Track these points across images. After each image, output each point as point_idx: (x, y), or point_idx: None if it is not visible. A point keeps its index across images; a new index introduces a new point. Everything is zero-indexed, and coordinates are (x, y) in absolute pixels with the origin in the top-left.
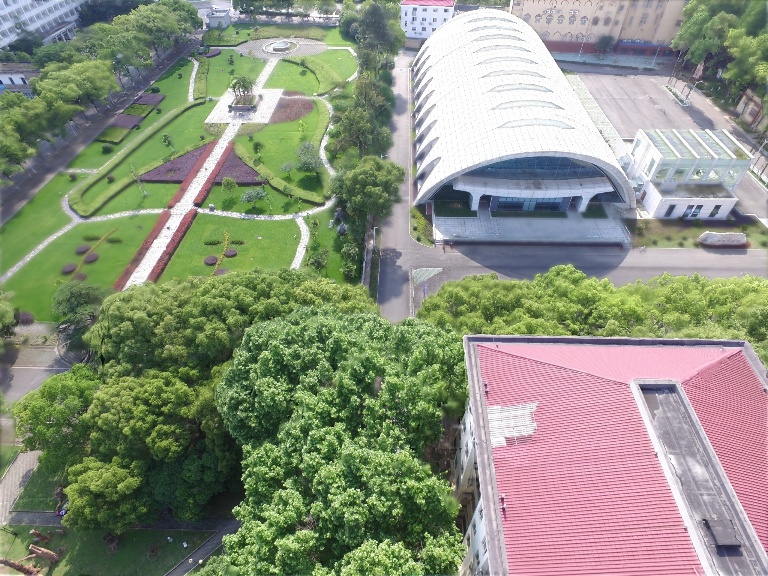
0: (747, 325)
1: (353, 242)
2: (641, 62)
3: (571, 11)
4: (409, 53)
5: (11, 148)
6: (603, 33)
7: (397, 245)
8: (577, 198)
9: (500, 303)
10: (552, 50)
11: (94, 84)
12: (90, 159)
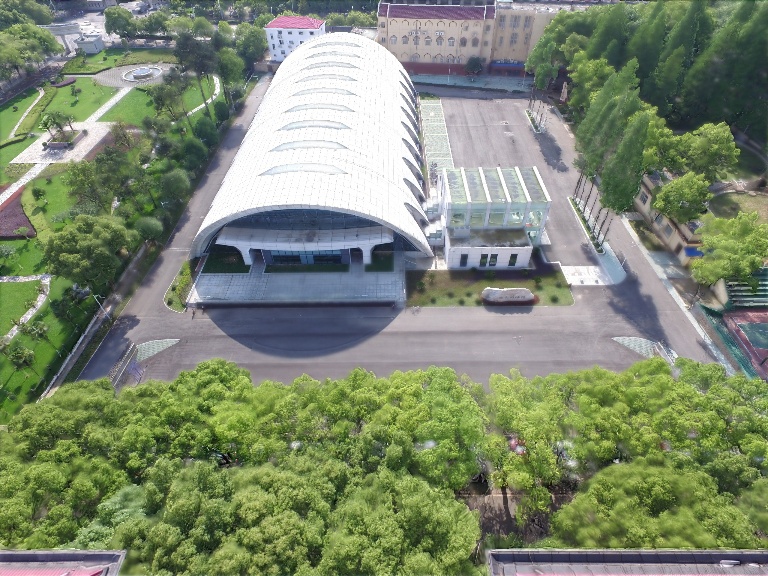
0: (364, 450)
1: (55, 316)
2: (513, 84)
3: (436, 32)
4: None
5: None
6: (473, 54)
7: (141, 311)
8: (358, 249)
9: (53, 431)
10: (425, 72)
11: None
12: None
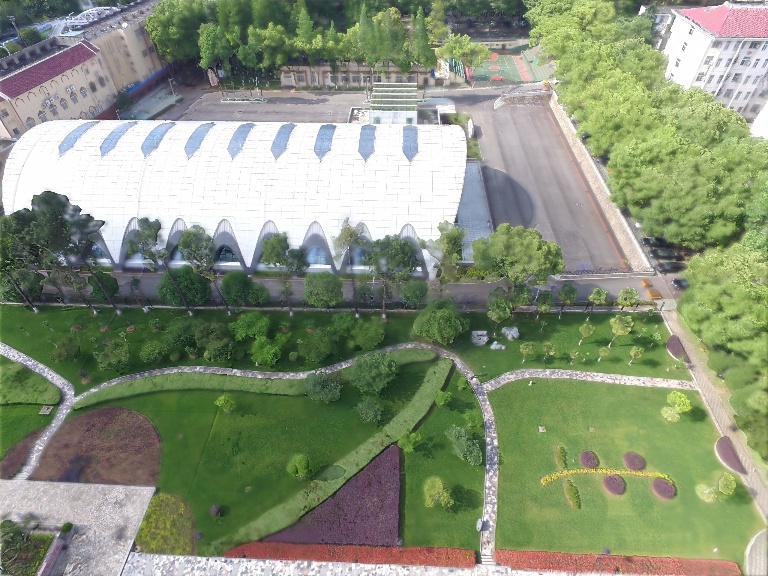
0: None
1: None
2: (159, 100)
3: (67, 89)
4: None
5: None
6: (107, 95)
7: None
8: None
9: None
10: None
11: None
12: None
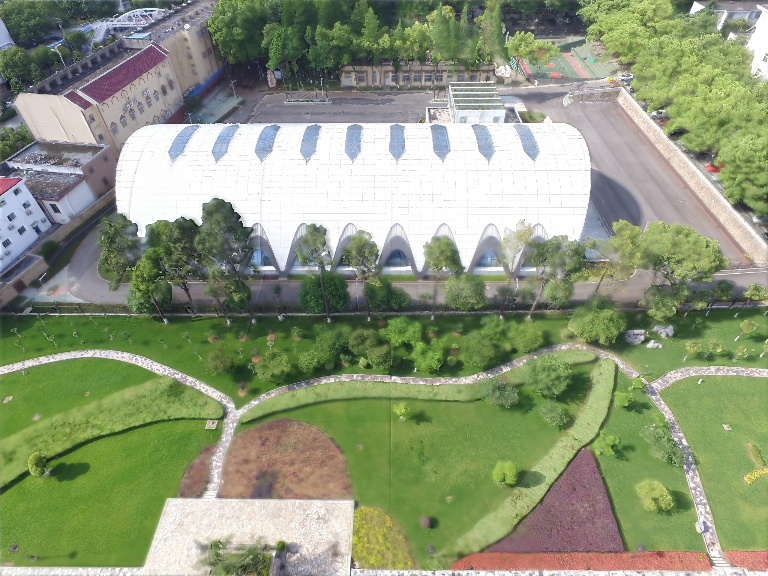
0: None
1: None
2: (220, 103)
3: (144, 93)
4: (58, 282)
5: None
6: (175, 98)
7: None
8: None
9: None
10: None
11: None
12: None
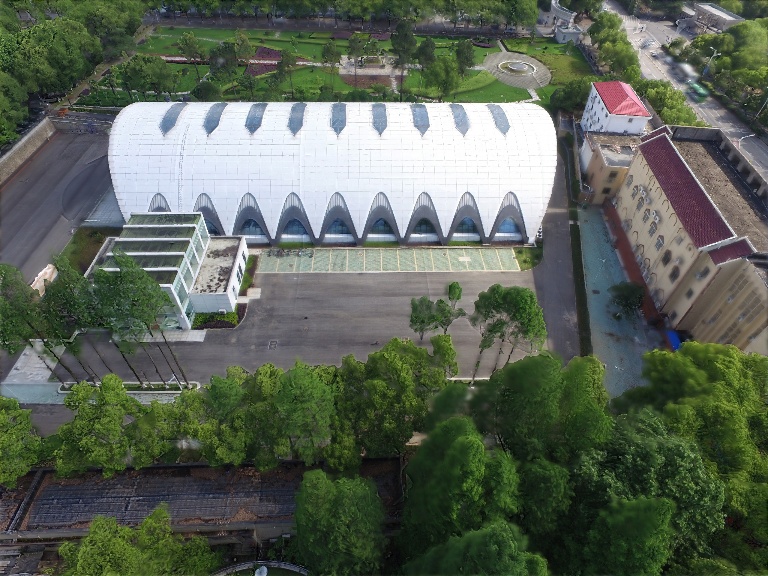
0: None
1: None
2: (634, 381)
3: (655, 211)
4: None
5: (252, 1)
6: (664, 289)
7: None
8: None
9: None
10: (623, 254)
11: (340, 3)
12: (290, 35)
